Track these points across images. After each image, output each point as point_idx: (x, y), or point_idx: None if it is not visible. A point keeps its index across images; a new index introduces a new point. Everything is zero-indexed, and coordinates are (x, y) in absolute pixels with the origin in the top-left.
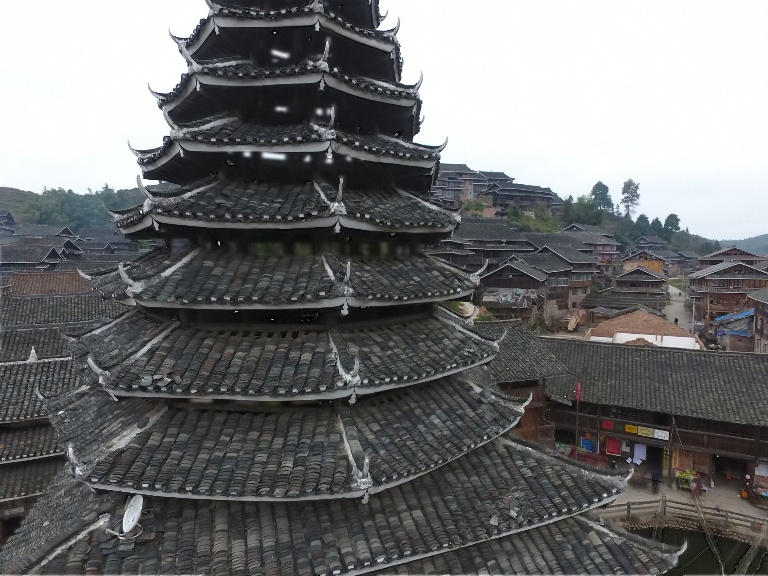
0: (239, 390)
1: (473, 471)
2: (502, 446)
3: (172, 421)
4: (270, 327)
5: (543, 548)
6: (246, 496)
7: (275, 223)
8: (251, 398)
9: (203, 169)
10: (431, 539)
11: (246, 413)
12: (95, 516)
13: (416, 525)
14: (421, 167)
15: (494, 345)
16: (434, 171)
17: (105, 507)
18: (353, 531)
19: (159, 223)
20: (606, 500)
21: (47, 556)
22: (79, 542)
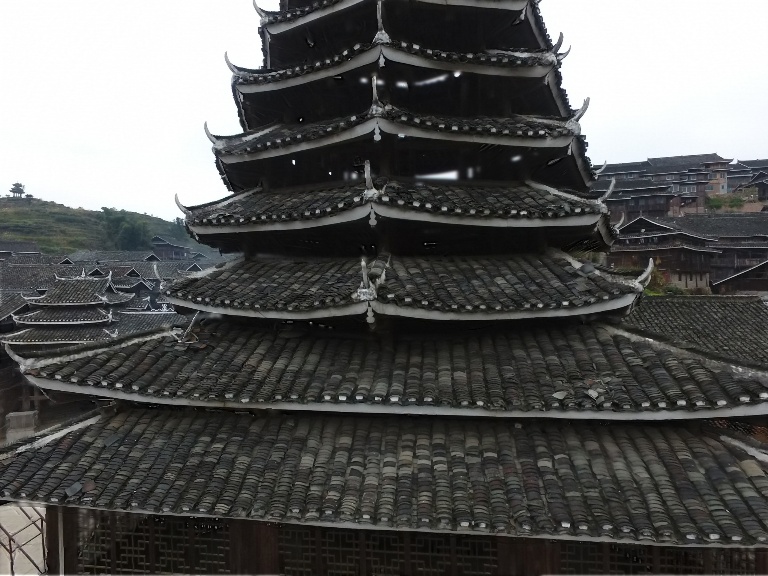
0: (275, 217)
1: (554, 352)
2: (607, 334)
3: (243, 266)
4: (331, 184)
5: (650, 459)
6: (269, 312)
7: (326, 69)
8: (286, 226)
9: (296, 60)
10: (463, 394)
11: (302, 263)
12: (170, 326)
13: (453, 383)
14: (506, 10)
15: (596, 203)
16: (533, 22)
17: None
18: (379, 375)
19: (243, 94)
20: None
21: (126, 341)
22: (152, 340)
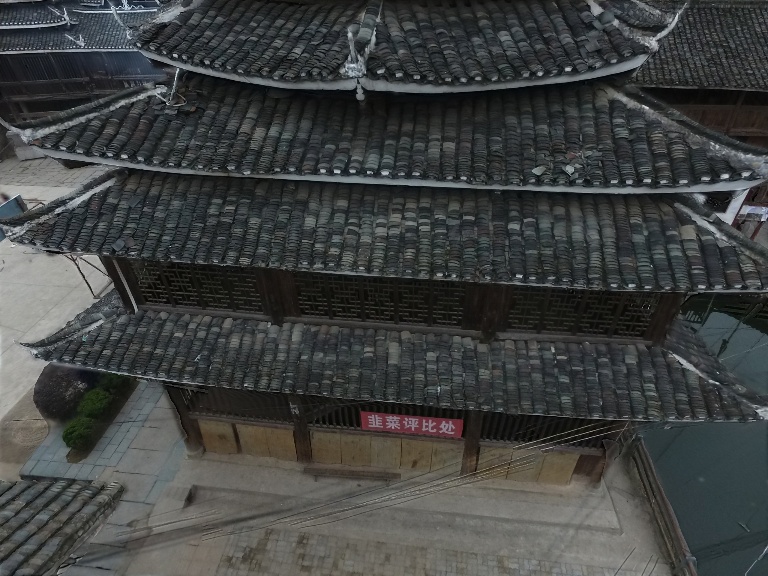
0: None
1: (546, 120)
2: (606, 99)
3: (213, 5)
4: None
5: (605, 224)
6: (254, 78)
7: None
8: None
9: None
10: (449, 169)
11: (282, 3)
12: (152, 84)
13: (441, 155)
14: None
15: None
16: None
17: (161, 79)
18: (371, 145)
19: None
20: (725, 185)
21: (113, 104)
22: (139, 101)
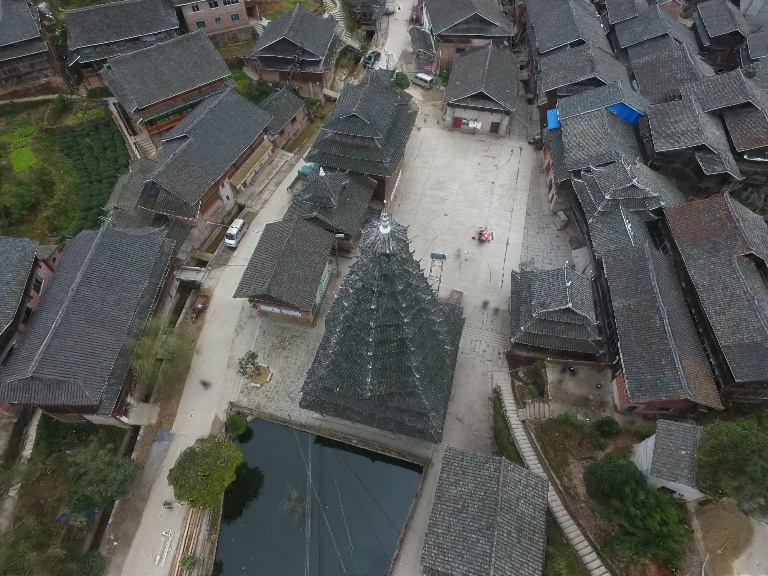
0: None
1: None
2: None
3: None
4: None
5: None
6: None
7: None
8: None
9: None
10: None
11: None
12: None
13: None
14: None
15: None
16: None
17: None
18: None
19: None
20: None
21: None
22: None
